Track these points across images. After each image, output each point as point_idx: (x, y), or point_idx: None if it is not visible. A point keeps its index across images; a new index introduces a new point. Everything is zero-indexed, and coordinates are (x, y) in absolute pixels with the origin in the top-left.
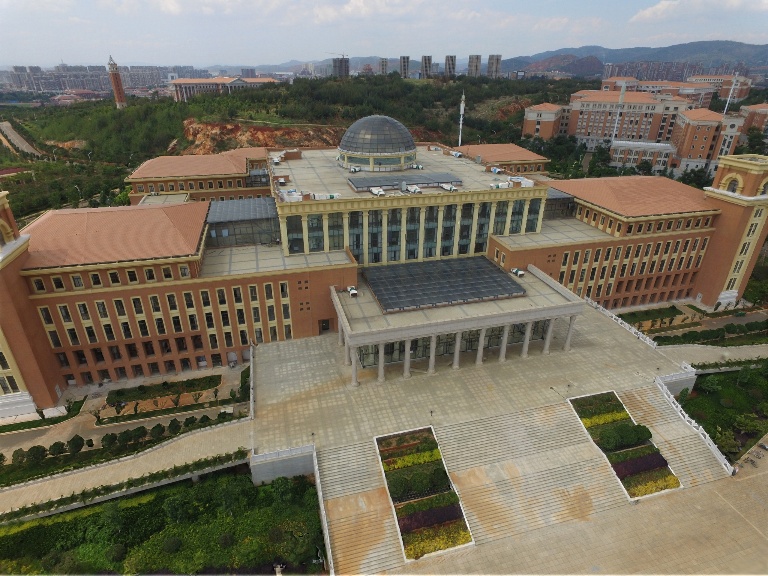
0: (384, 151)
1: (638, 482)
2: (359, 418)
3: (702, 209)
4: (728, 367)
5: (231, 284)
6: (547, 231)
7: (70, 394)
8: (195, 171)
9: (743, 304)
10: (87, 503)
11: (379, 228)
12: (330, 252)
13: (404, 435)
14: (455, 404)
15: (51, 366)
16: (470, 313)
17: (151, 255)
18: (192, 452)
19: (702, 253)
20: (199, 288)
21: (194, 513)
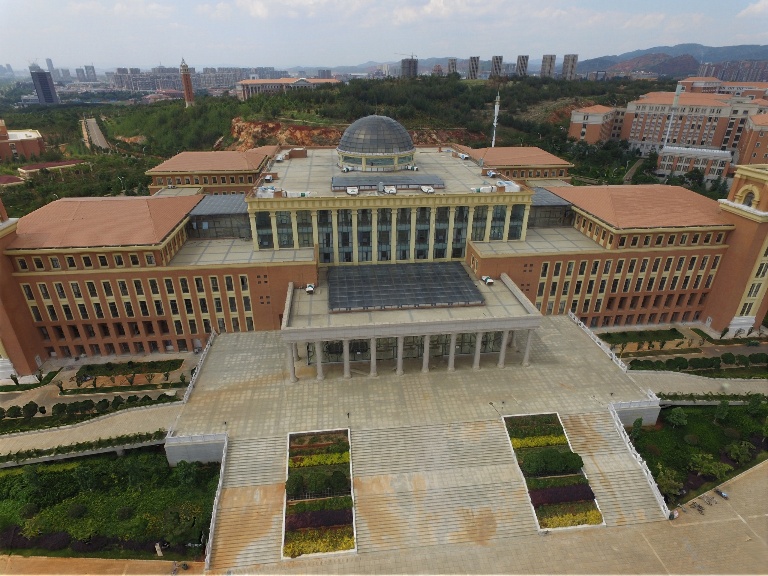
0: (376, 151)
1: (554, 512)
2: (283, 413)
3: (711, 223)
4: (706, 400)
5: (192, 274)
6: (534, 239)
7: (49, 365)
8: (210, 166)
9: (759, 332)
10: (20, 463)
11: (349, 228)
12: (299, 249)
13: (319, 434)
14: (383, 409)
15: (32, 338)
16: (416, 318)
17: (119, 242)
18: (121, 428)
19: (713, 272)
20: (163, 276)
21: (108, 484)
